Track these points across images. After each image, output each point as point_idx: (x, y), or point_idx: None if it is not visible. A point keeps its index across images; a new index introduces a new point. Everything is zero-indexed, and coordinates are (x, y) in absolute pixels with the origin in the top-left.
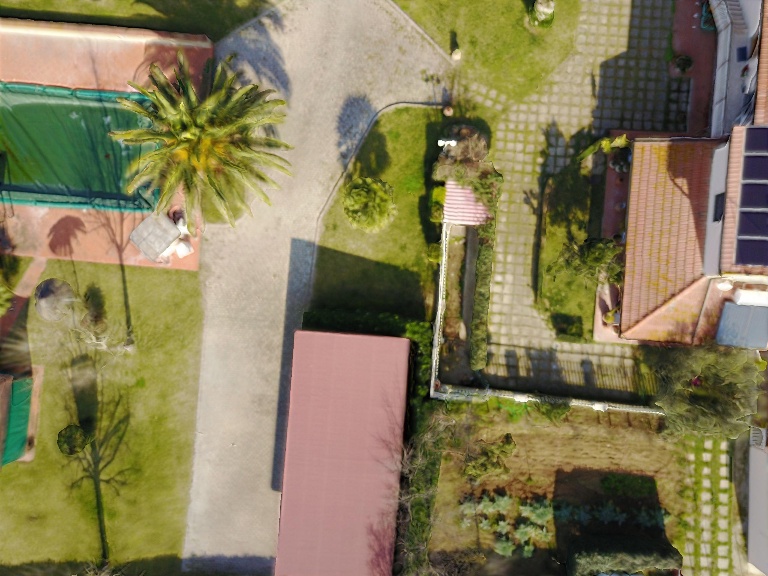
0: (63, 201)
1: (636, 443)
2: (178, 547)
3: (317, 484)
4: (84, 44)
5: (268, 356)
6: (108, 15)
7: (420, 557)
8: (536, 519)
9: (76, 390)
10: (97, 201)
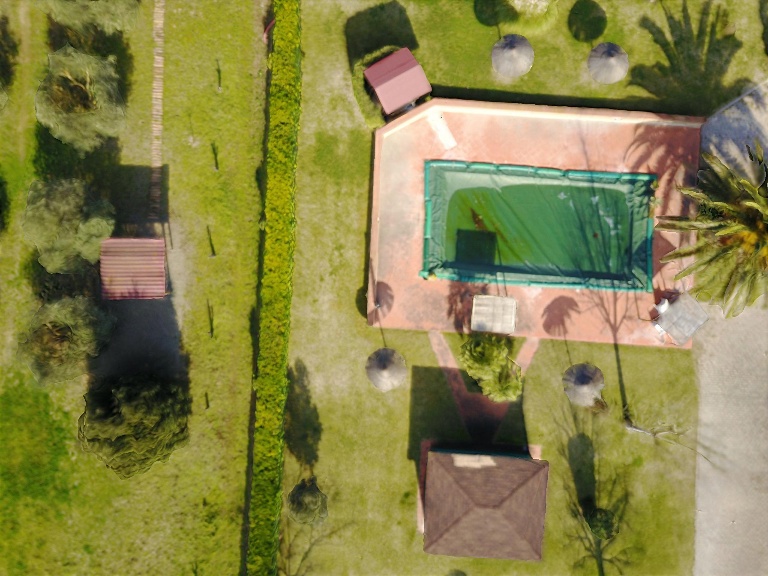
0: (556, 281)
1: None
2: None
3: None
4: (574, 126)
5: (763, 433)
6: (602, 98)
7: None
8: None
9: (574, 469)
10: (591, 281)
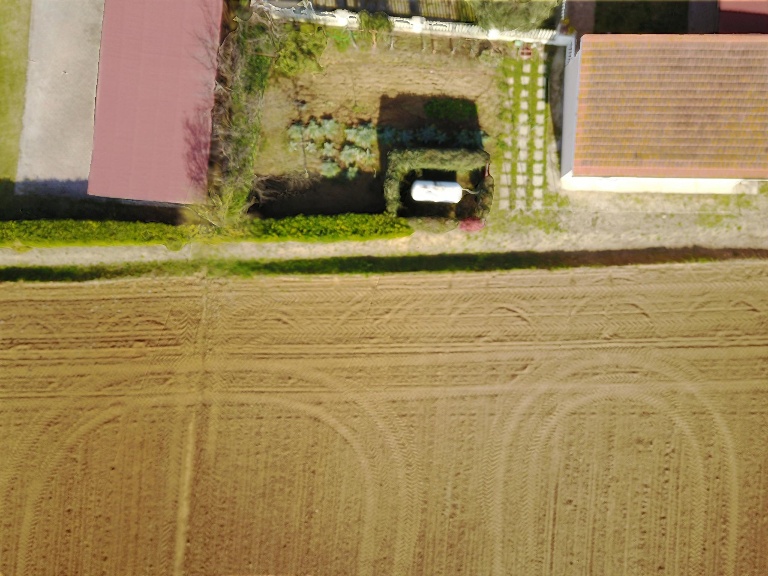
0: None
1: (458, 69)
2: (11, 172)
3: (133, 77)
4: None
5: None
6: None
7: (239, 161)
8: (360, 142)
9: None
10: None
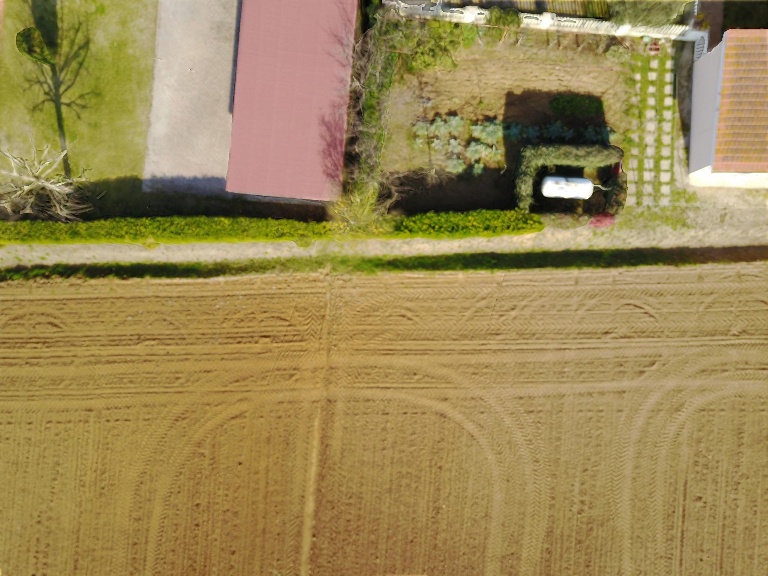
0: None
1: (584, 65)
2: (138, 169)
3: (270, 74)
4: None
5: None
6: None
7: None
8: (486, 139)
9: (36, 16)
10: None
